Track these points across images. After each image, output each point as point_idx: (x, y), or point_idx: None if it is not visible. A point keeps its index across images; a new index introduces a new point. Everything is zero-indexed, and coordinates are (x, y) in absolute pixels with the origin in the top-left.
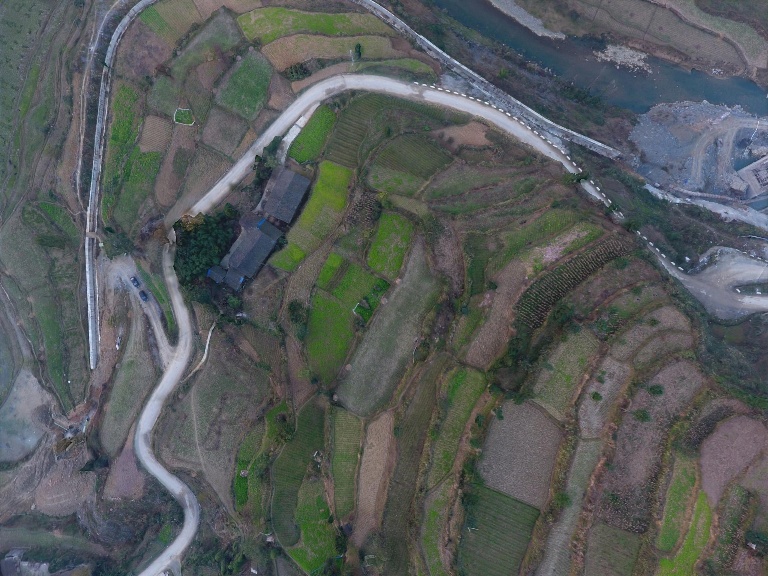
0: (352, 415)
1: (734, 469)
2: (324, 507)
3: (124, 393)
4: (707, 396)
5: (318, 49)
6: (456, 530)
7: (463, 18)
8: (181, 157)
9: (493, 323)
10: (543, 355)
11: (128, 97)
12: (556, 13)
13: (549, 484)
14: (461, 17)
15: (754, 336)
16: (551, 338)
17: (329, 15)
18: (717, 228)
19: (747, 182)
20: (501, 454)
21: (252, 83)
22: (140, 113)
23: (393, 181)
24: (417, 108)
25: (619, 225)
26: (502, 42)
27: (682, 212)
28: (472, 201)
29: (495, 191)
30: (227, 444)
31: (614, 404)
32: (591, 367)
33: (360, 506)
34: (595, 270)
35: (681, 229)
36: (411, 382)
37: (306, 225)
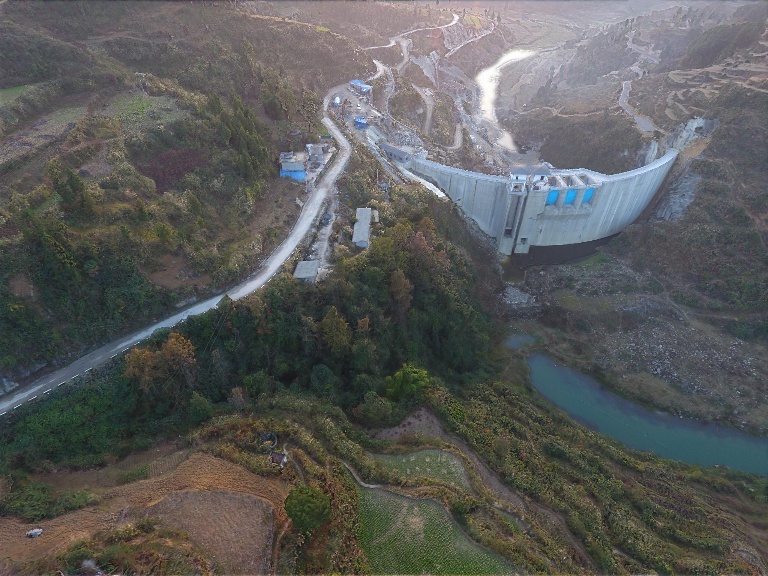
0: None
1: None
2: None
3: None
4: None
5: None
6: None
7: (498, 60)
8: None
9: None
10: None
11: None
12: None
13: None
14: None
15: None
16: None
17: None
18: None
19: None
20: None
21: None
22: None
23: None
24: None
25: None
26: (492, 64)
27: None
28: None
29: None
30: None
31: None
32: None
33: None
34: None
35: None
36: None
37: None
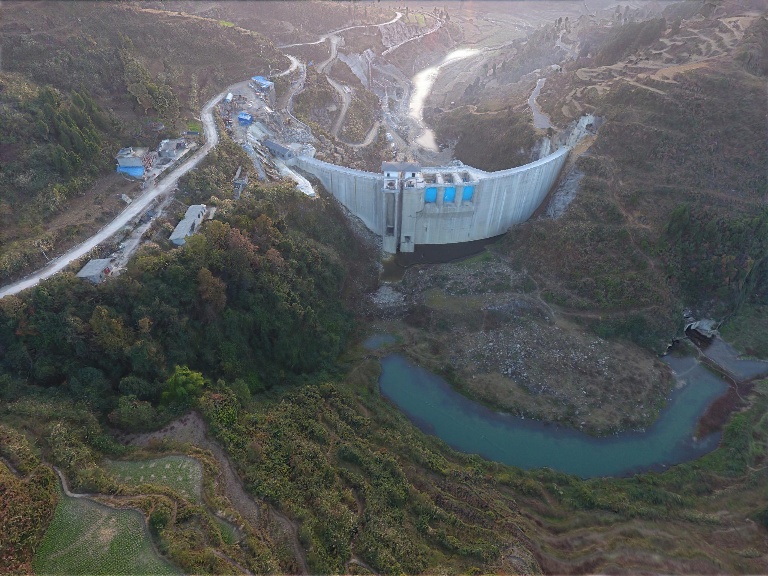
0: None
1: None
2: None
3: None
4: None
5: None
6: None
7: None
8: None
9: None
10: None
11: None
12: None
13: None
14: None
15: None
16: None
17: None
18: None
19: None
20: None
21: None
22: None
23: None
24: None
25: None
26: None
27: None
28: None
29: None
30: None
31: None
32: None
33: None
34: None
35: None
36: None
37: None
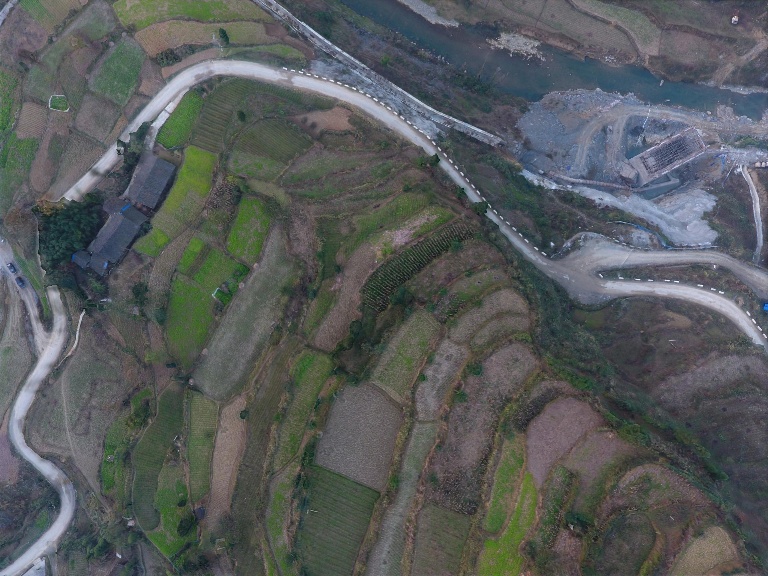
0: (208, 399)
1: (559, 450)
2: (183, 491)
3: (1, 379)
4: (537, 378)
5: (191, 35)
6: (298, 513)
7: (357, 6)
8: (56, 143)
9: (342, 307)
10: (384, 338)
11: (7, 84)
12: (449, 1)
13: (389, 467)
14: (355, 5)
15: (613, 321)
16: (394, 321)
17: (206, 1)
18: (588, 214)
19: (637, 170)
20: (342, 437)
21: (125, 69)
22: (19, 100)
23: (253, 166)
24: (282, 93)
25: (470, 209)
26: (396, 30)
27: (556, 198)
28: (329, 185)
29: (352, 175)
30: (97, 429)
31: (451, 386)
32: (430, 350)
33: (213, 490)
34: (440, 253)
35: (551, 215)
36: (263, 366)
37: (170, 210)
